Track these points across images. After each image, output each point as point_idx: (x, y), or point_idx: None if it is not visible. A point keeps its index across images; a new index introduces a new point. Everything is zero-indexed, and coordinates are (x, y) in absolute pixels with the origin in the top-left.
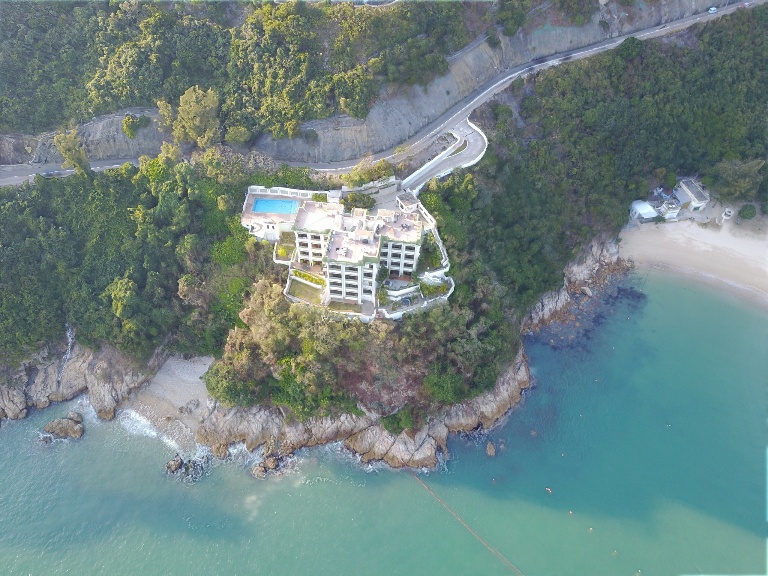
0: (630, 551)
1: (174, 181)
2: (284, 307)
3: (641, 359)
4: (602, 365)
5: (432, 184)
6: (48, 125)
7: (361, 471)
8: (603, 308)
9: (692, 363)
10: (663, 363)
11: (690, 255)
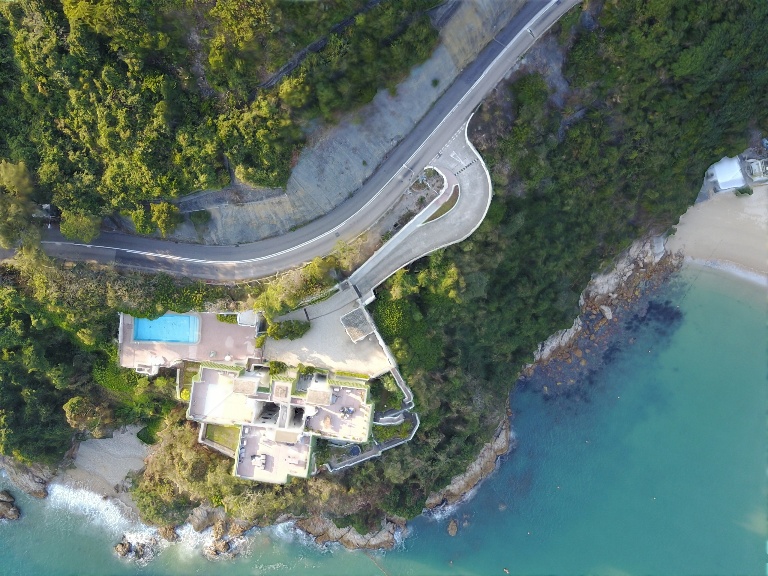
0: None
1: (5, 304)
2: (200, 472)
3: (648, 408)
4: (599, 418)
5: (395, 293)
6: None
7: (315, 553)
8: (621, 336)
9: (708, 417)
10: (673, 416)
11: (766, 244)
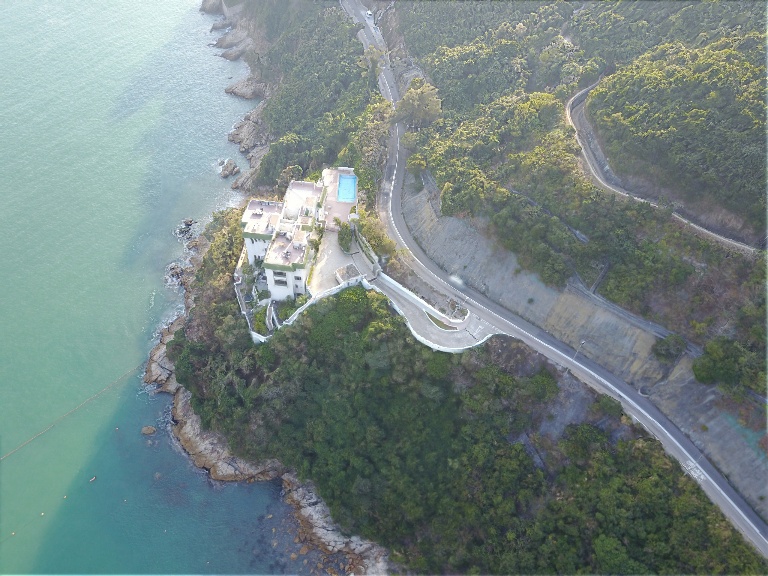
0: (8, 549)
1: None
2: None
3: None
4: None
5: None
6: (416, 54)
7: (155, 328)
8: None
9: None
10: None
11: None
